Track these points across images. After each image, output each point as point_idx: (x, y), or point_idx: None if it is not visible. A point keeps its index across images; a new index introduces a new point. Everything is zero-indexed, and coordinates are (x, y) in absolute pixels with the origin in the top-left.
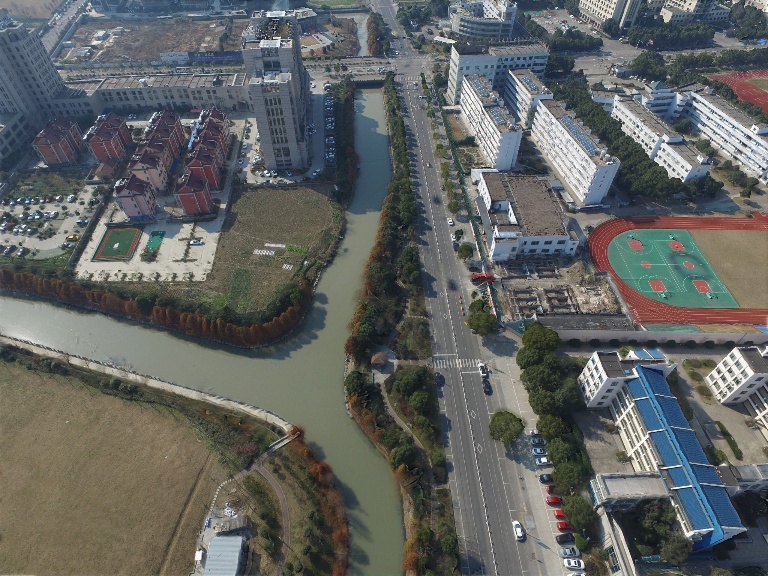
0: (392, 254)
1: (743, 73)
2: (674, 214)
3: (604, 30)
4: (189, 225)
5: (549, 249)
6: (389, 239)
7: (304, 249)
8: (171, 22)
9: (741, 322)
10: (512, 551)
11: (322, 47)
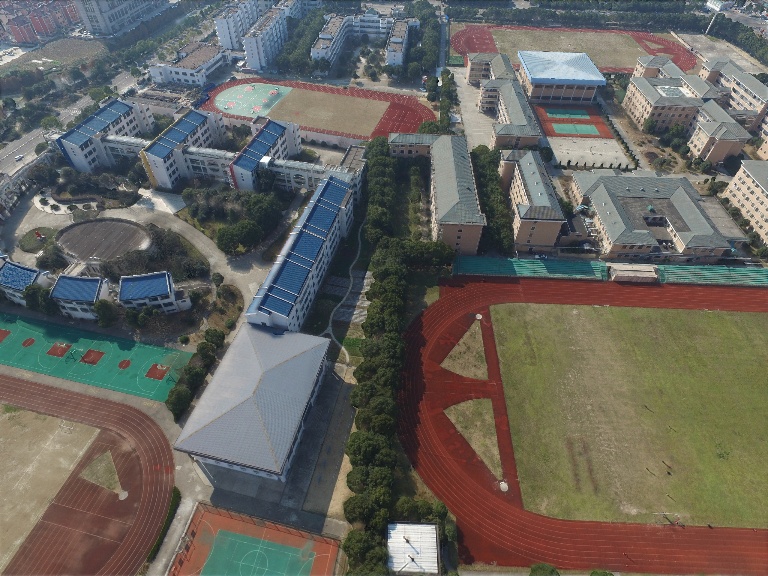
0: None
1: (497, 26)
2: (298, 81)
3: None
4: (16, 47)
5: (188, 80)
6: (100, 60)
7: (59, 63)
8: None
9: None
10: (8, 162)
11: None
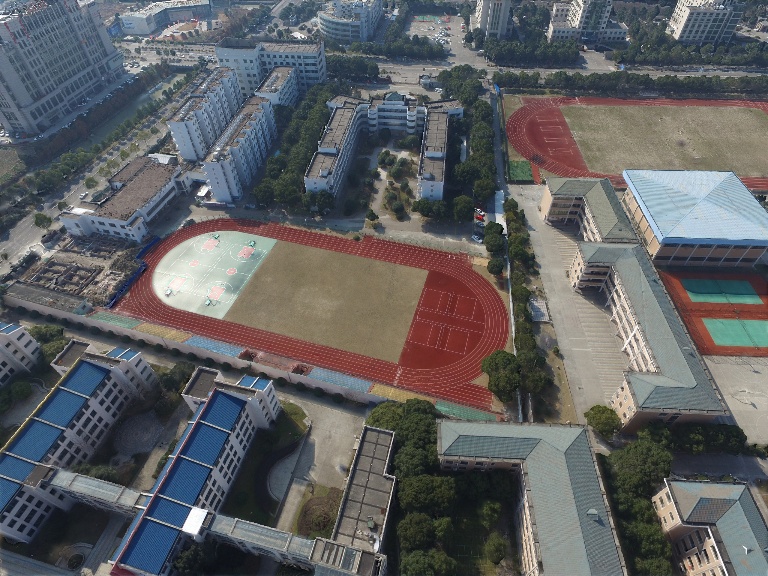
0: (0, 213)
1: (568, 99)
2: (286, 224)
3: (465, 40)
4: None
5: (119, 232)
6: None
7: None
8: (102, 1)
9: (203, 331)
10: None
11: (181, 33)
